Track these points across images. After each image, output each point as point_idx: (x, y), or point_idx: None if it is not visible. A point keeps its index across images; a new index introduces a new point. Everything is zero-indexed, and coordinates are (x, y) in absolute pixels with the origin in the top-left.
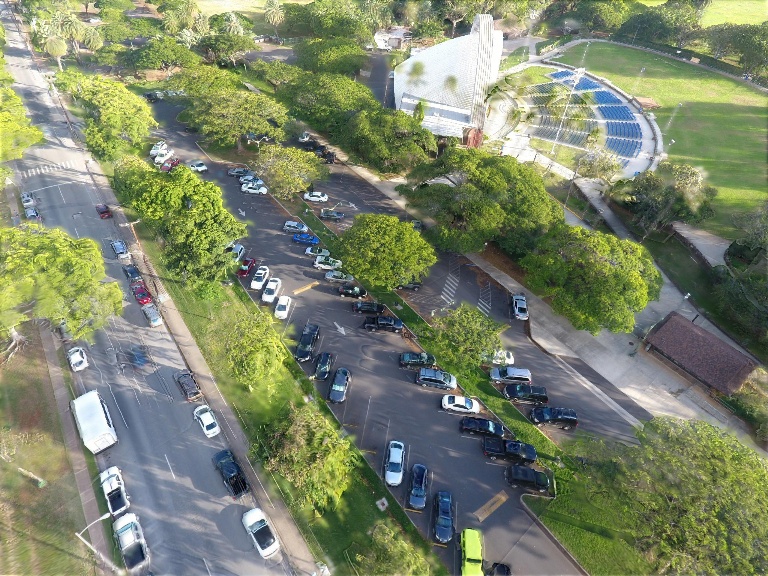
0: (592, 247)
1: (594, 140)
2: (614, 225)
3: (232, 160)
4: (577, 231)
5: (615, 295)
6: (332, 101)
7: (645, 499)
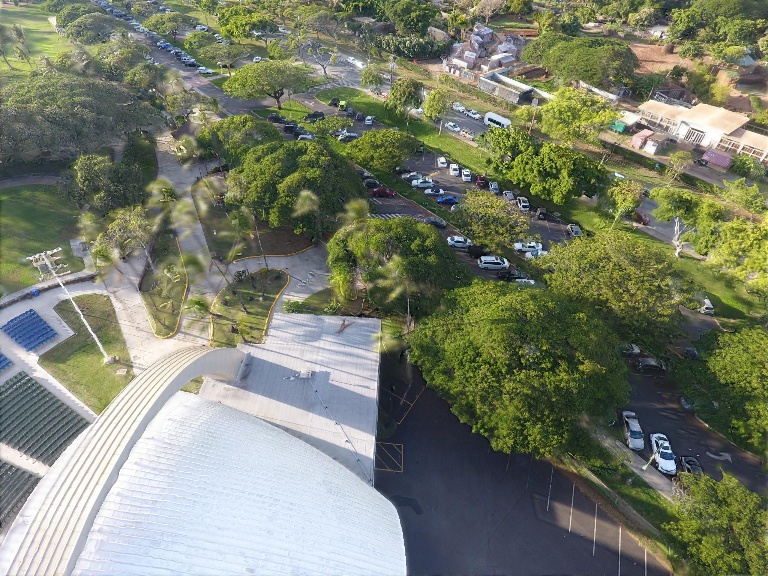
0: None
1: None
2: None
3: None
4: None
5: None
6: None
7: None
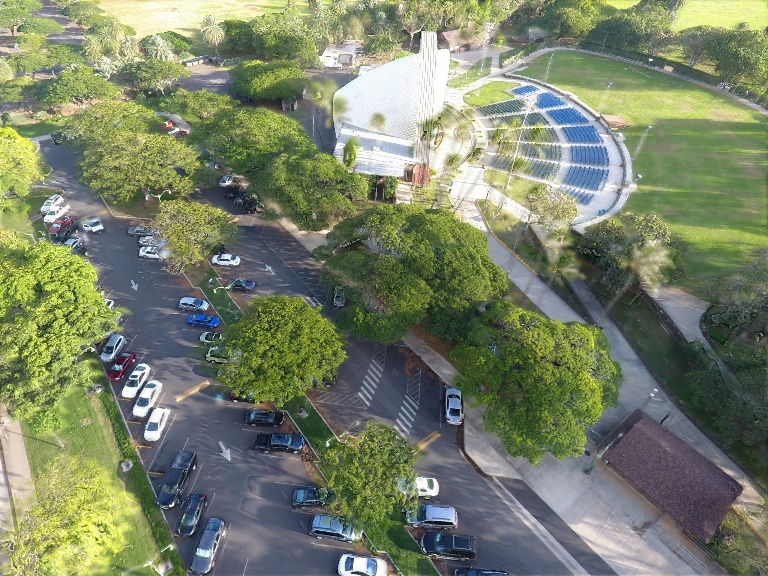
0: (530, 344)
1: (535, 198)
2: (573, 281)
3: (137, 214)
4: (514, 319)
5: (560, 408)
6: (249, 142)
7: None
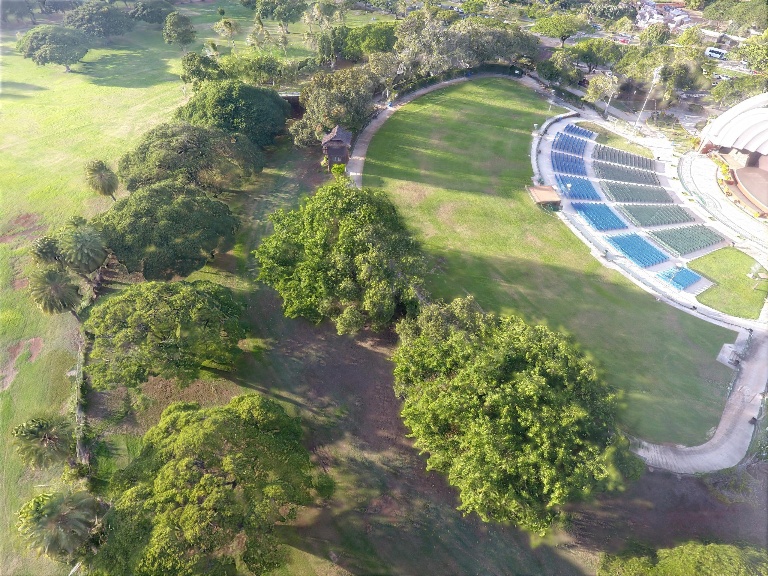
0: None
1: None
2: None
3: None
4: None
5: None
6: None
7: None
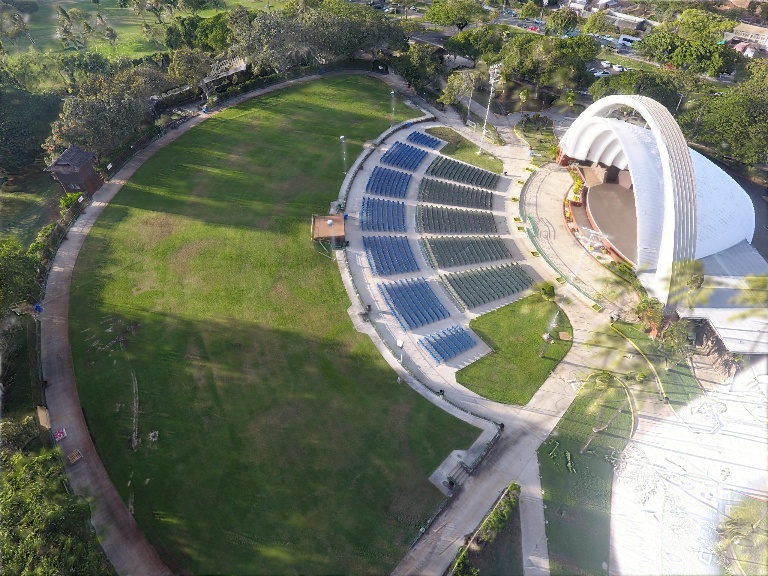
0: None
1: None
2: None
3: None
4: None
5: None
6: None
7: (479, 4)
